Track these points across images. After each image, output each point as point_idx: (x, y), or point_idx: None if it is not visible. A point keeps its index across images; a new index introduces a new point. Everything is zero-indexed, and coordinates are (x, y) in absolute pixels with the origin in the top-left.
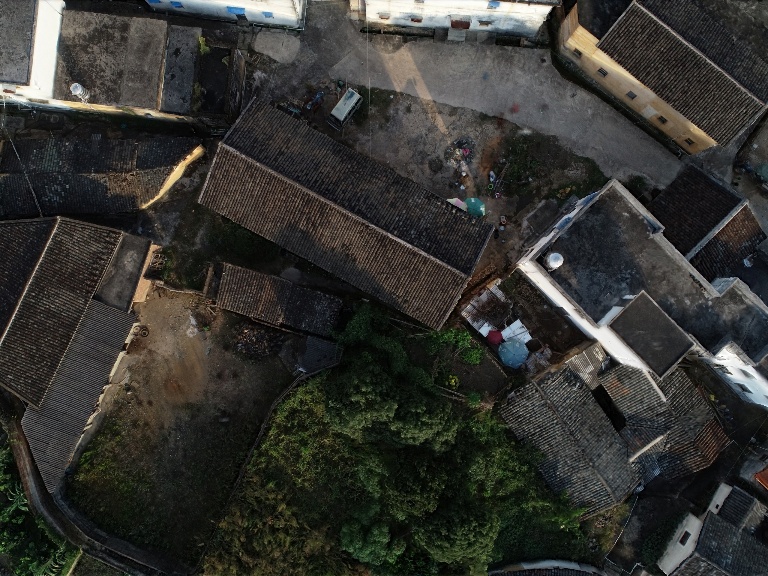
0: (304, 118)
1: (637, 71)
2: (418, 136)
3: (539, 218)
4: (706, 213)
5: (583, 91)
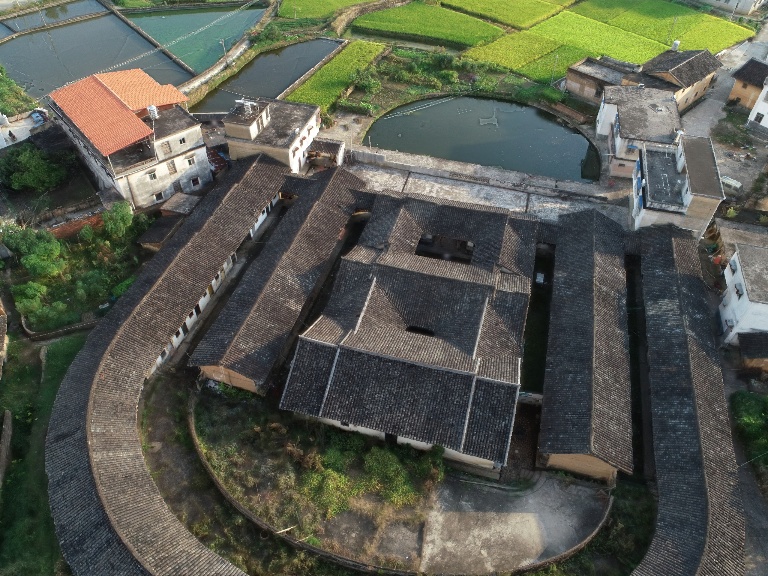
0: (740, 205)
1: (696, 80)
2: (730, 169)
3: (760, 137)
4: (761, 69)
5: (682, 119)
